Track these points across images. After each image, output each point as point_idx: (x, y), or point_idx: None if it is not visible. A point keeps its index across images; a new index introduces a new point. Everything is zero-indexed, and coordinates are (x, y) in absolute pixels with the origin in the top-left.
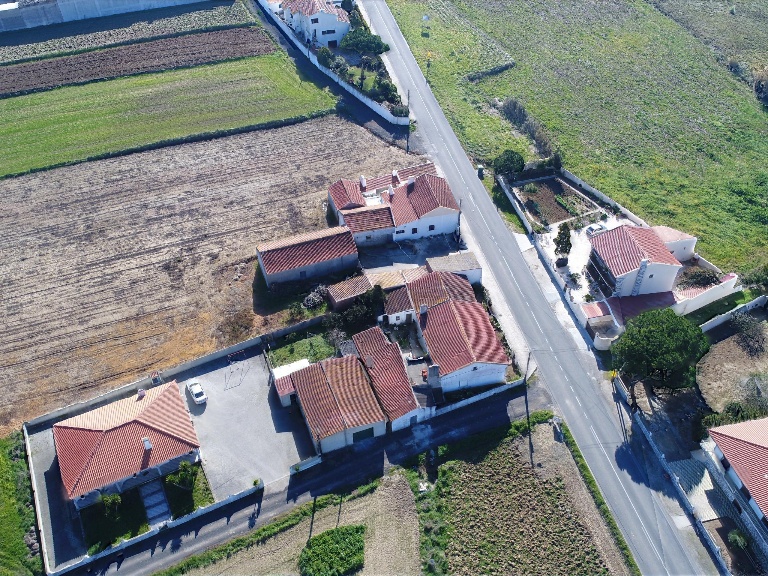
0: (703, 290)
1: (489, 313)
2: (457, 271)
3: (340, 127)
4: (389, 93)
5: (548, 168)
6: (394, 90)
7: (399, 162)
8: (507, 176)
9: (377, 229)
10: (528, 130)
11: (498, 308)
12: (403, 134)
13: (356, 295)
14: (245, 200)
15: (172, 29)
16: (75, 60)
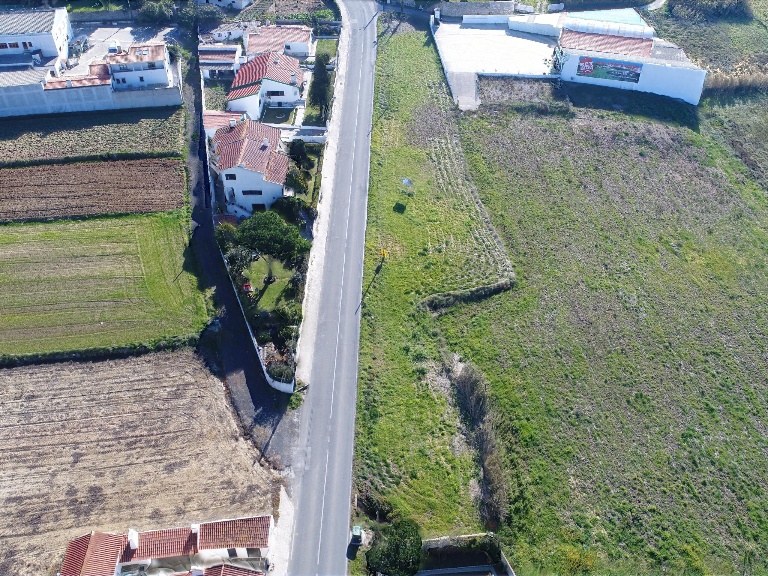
0: None
1: None
2: None
3: (188, 377)
4: (280, 329)
5: None
6: (295, 320)
7: (234, 482)
8: None
9: None
10: (479, 443)
11: None
12: (274, 413)
13: None
14: None
15: (64, 150)
16: None
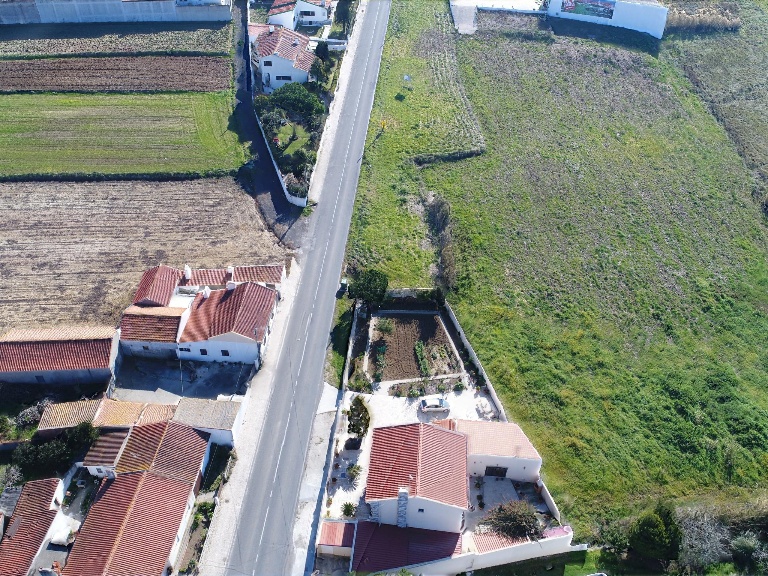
0: (508, 543)
1: (215, 494)
2: (198, 427)
3: (229, 194)
4: (299, 164)
5: (432, 300)
6: (311, 161)
7: (259, 253)
8: (369, 301)
9: (154, 341)
10: (440, 243)
11: (231, 489)
12: (290, 217)
13: (65, 427)
14: (60, 264)
15: (137, 47)
16: (20, 66)
